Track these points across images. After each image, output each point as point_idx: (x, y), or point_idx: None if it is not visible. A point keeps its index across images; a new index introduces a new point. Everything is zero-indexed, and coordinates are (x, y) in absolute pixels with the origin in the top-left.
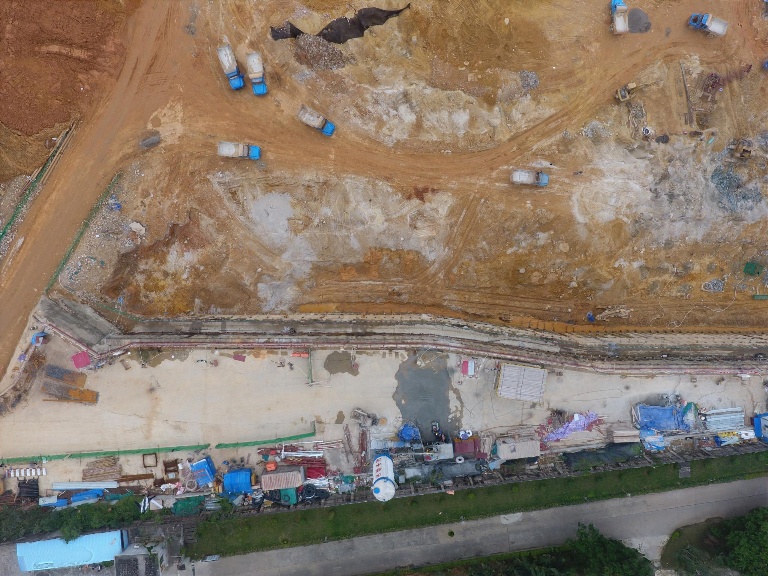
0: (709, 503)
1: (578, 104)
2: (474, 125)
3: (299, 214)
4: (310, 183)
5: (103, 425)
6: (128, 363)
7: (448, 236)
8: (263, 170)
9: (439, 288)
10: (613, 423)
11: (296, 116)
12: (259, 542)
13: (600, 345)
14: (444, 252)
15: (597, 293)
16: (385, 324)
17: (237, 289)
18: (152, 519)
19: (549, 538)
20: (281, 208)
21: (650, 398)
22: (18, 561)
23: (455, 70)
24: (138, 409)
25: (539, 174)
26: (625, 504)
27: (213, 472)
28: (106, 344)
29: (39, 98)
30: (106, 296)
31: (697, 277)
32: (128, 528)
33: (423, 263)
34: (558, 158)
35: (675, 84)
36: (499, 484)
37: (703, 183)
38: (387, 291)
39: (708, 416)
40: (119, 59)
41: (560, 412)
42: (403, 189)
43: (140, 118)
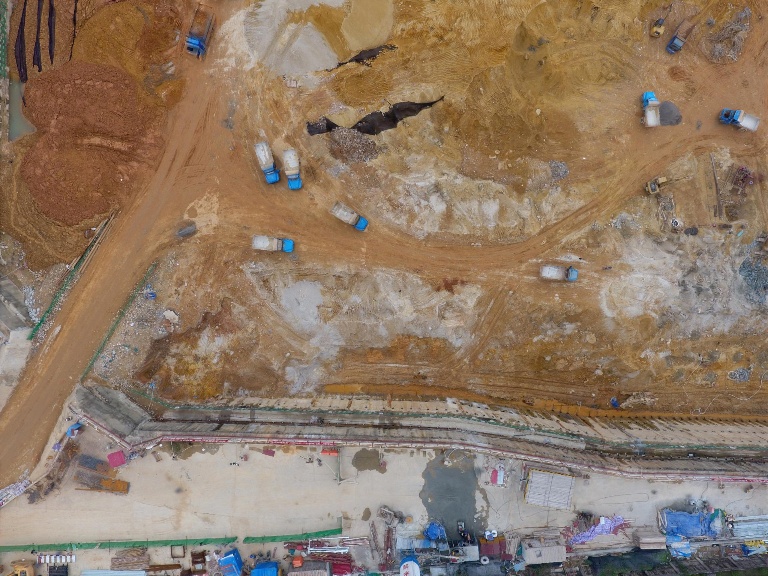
0: None
1: (608, 195)
2: (504, 216)
3: (329, 301)
4: (341, 274)
5: (133, 515)
6: (159, 455)
7: (475, 324)
8: (296, 262)
9: (464, 372)
10: (639, 527)
11: (330, 212)
12: None
13: (626, 442)
14: (470, 339)
15: (622, 380)
16: (412, 416)
17: (265, 373)
18: None
19: None
20: (312, 297)
21: (677, 503)
22: None
23: (486, 158)
24: (168, 500)
25: (569, 271)
26: None
27: (240, 566)
28: (138, 436)
29: (80, 191)
30: (138, 381)
31: (723, 366)
32: None
33: (449, 349)
34: (587, 253)
35: (705, 176)
36: None
37: (731, 275)
38: (412, 374)
39: (735, 523)
40: (158, 151)
41: (586, 515)
42: (433, 281)
43: (177, 209)
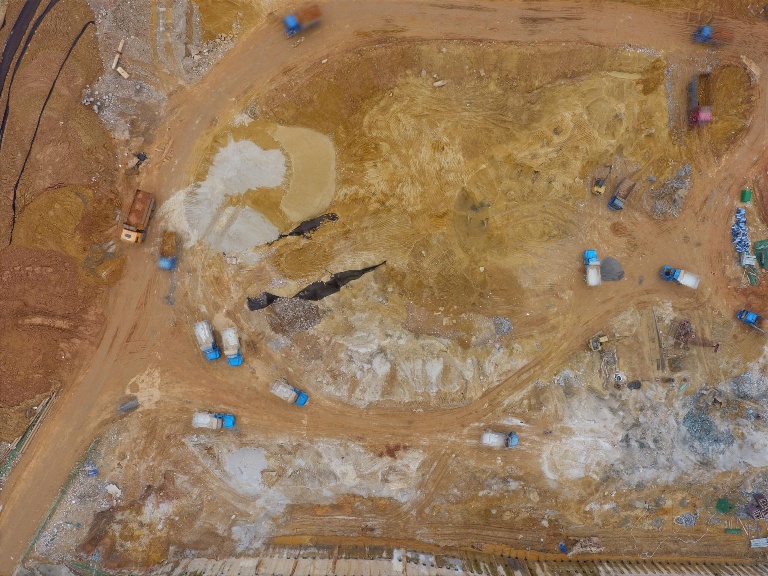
0: None
1: (551, 351)
2: (447, 377)
3: (273, 465)
4: (283, 444)
5: None
6: None
7: (420, 482)
8: (237, 435)
9: (412, 524)
10: None
11: None
12: None
13: None
14: (416, 494)
15: (569, 526)
16: None
17: (211, 534)
18: None
19: None
20: (255, 464)
21: None
22: None
23: (430, 314)
24: None
25: (508, 440)
26: None
27: None
28: None
29: (21, 375)
30: (81, 553)
31: (669, 511)
32: None
33: (395, 504)
34: (528, 416)
35: (648, 330)
36: None
37: (675, 427)
38: (360, 526)
39: None
40: (100, 328)
41: None
42: (375, 448)
43: (119, 384)
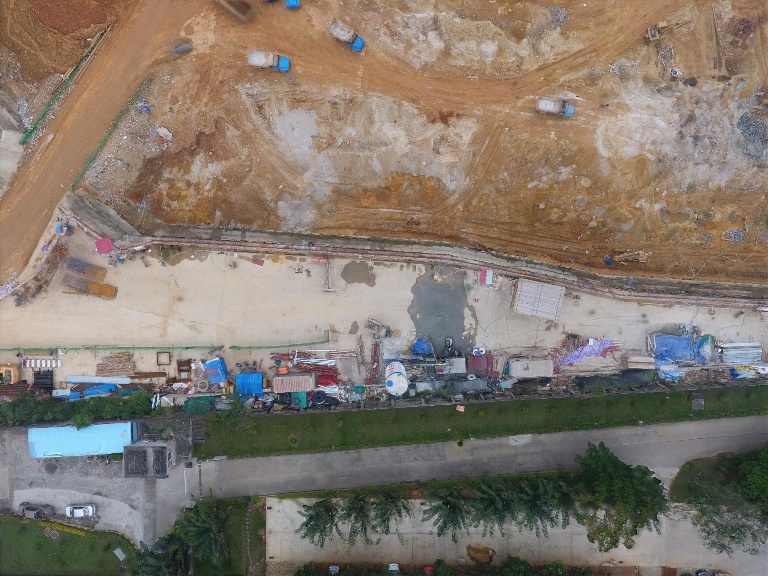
0: (721, 437)
1: (607, 42)
2: (502, 55)
3: (324, 133)
4: (337, 100)
5: (120, 321)
6: (148, 260)
7: (470, 165)
8: (291, 83)
9: (458, 220)
10: (628, 350)
11: (327, 29)
12: (266, 447)
13: (618, 277)
14: (465, 182)
15: (616, 235)
16: (403, 243)
17: (258, 205)
18: (162, 415)
19: (557, 462)
20: (306, 124)
21: (667, 327)
22: (29, 447)
23: (486, 3)
24: (155, 307)
25: (565, 102)
26: (636, 433)
27: (225, 373)
28: (128, 240)
29: None
30: (129, 200)
31: (718, 225)
32: (139, 420)
33: (443, 192)
34: (585, 90)
35: (706, 28)
36: (510, 400)
37: (729, 128)
38: (406, 220)
39: (725, 349)
40: None
41: (575, 335)
42: (428, 112)
43: (174, 25)
